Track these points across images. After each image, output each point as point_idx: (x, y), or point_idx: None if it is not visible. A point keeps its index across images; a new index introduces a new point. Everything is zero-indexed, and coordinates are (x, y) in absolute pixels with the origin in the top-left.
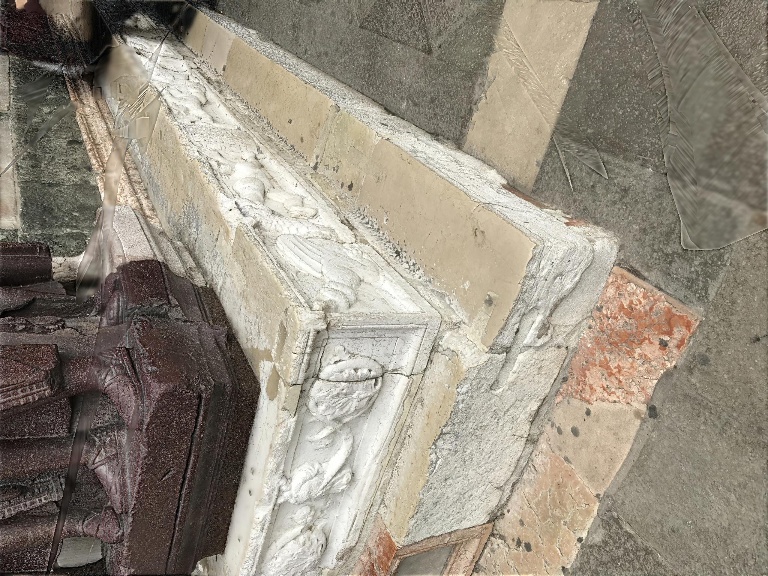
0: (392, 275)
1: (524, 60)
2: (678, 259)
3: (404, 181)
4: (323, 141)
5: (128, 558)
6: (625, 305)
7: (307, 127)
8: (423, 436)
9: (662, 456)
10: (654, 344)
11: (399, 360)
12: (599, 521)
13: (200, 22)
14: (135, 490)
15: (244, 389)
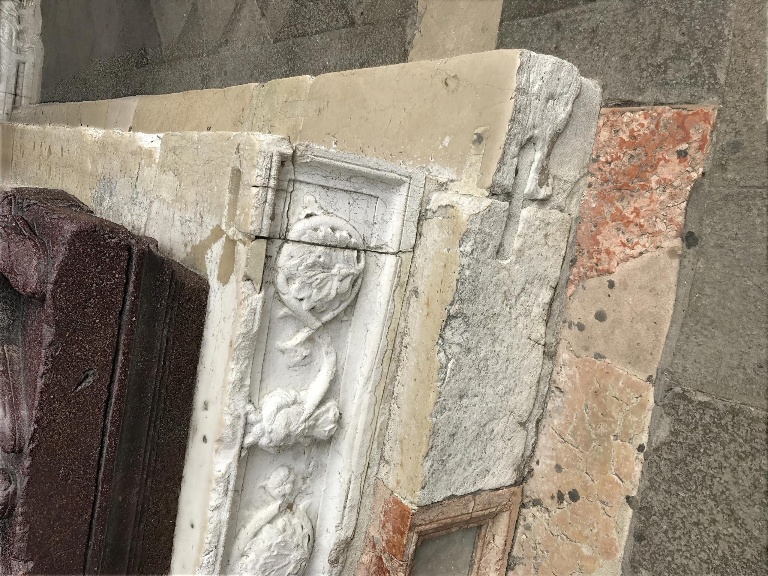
0: None
1: None
2: (672, 63)
3: (350, 92)
4: (249, 121)
5: (24, 538)
6: (626, 138)
7: (229, 121)
8: (425, 333)
9: (718, 283)
10: (672, 161)
11: (382, 232)
12: (660, 410)
13: (101, 107)
14: (35, 404)
15: (187, 284)
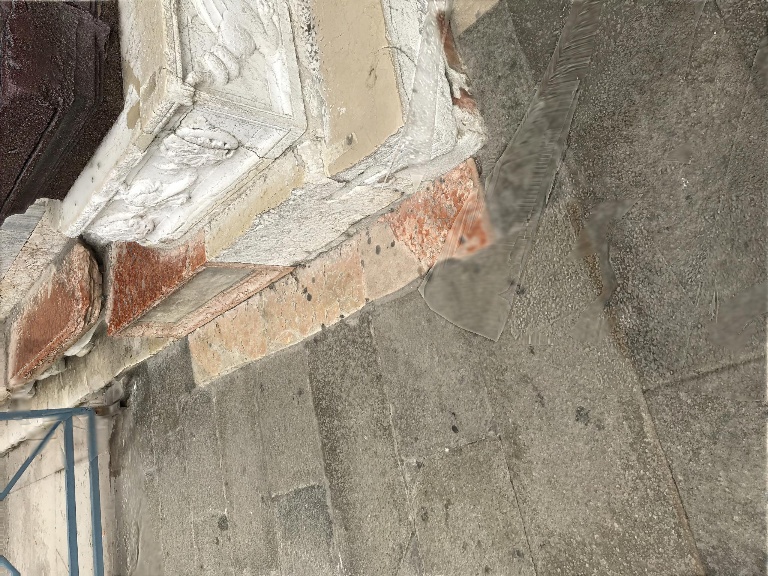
0: (288, 57)
1: (449, 1)
2: None
3: None
4: None
5: None
6: (458, 193)
7: None
8: (255, 203)
9: (417, 307)
10: None
11: (257, 142)
12: (359, 314)
13: None
14: None
15: (108, 102)
